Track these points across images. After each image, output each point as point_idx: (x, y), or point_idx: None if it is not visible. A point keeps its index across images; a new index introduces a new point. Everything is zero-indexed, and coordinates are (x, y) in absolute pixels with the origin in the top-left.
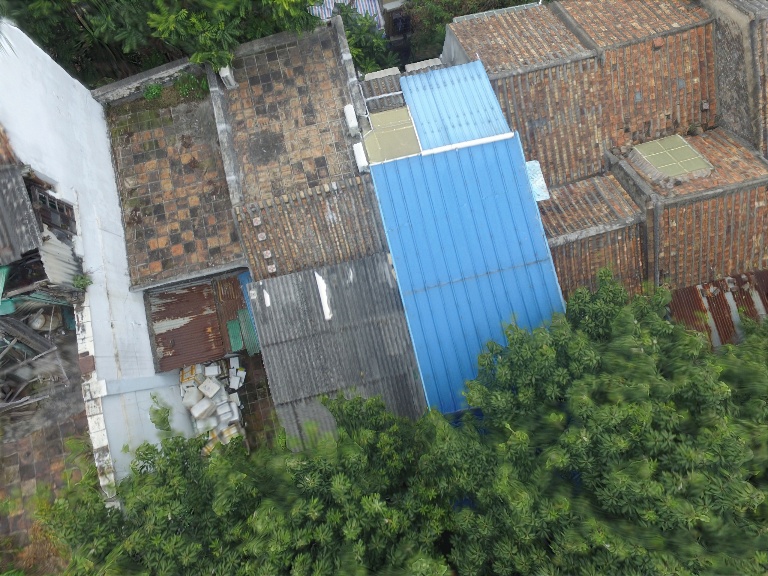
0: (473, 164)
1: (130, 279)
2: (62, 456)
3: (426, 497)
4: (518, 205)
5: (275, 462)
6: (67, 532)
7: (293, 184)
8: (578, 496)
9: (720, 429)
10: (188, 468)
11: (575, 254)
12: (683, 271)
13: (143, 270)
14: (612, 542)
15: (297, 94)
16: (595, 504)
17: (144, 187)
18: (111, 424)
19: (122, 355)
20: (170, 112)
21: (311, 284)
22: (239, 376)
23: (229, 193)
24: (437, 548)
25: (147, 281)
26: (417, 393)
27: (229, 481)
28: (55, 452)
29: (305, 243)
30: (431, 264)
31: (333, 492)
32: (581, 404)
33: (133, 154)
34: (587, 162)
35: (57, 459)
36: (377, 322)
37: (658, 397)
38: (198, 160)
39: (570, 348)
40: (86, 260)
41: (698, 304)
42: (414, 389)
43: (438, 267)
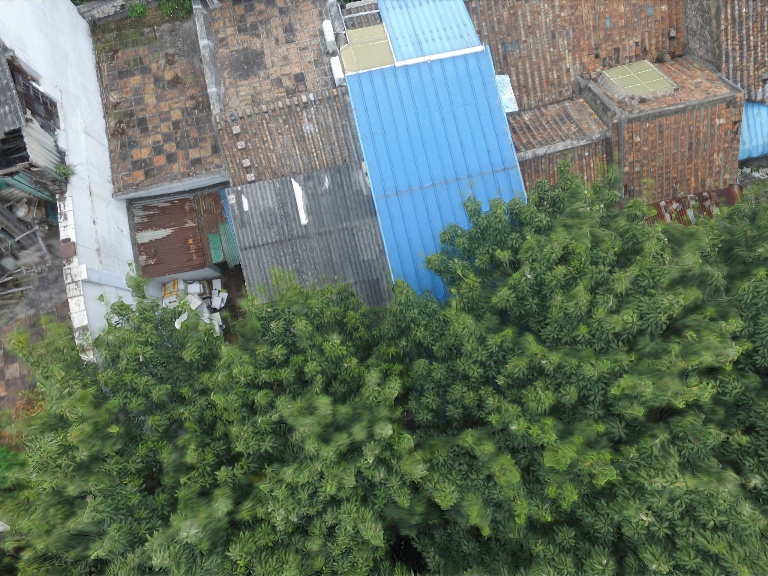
0: (445, 76)
1: (113, 187)
2: (44, 343)
3: (386, 356)
4: (487, 115)
5: (244, 324)
6: (44, 371)
7: (272, 98)
8: (523, 335)
9: (648, 250)
10: (162, 332)
11: (544, 169)
12: (647, 187)
13: (126, 178)
14: (548, 359)
15: (278, 14)
16: (539, 341)
17: (128, 101)
18: (91, 307)
19: (104, 251)
20: (154, 31)
21: (288, 190)
22: (221, 297)
23: (210, 104)
24: (395, 401)
25: (130, 189)
26: (389, 297)
27: (199, 332)
28: (38, 339)
29: (283, 153)
30: (403, 170)
31: (297, 342)
32: (527, 249)
33: (118, 70)
34: (558, 87)
35: (39, 345)
36: (351, 228)
37: (600, 246)
38: (181, 76)
39: (523, 213)
40: (69, 155)
41: (661, 219)
42: (386, 293)
43: (410, 173)
